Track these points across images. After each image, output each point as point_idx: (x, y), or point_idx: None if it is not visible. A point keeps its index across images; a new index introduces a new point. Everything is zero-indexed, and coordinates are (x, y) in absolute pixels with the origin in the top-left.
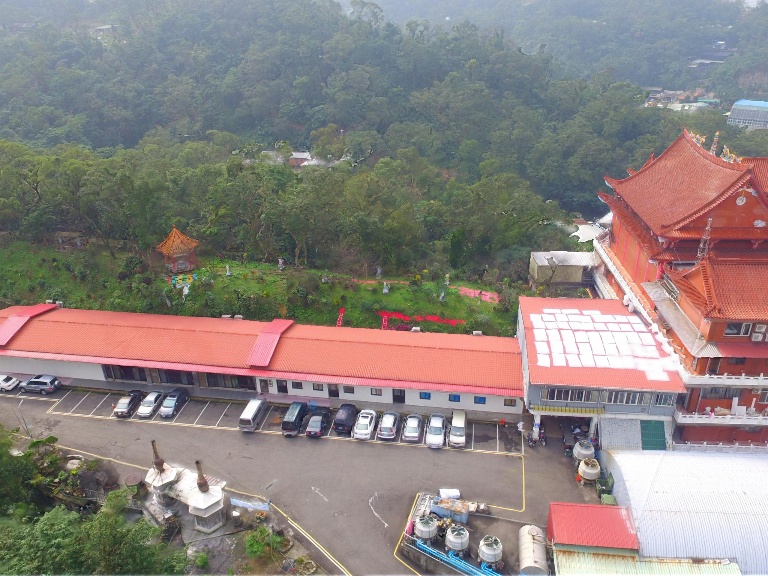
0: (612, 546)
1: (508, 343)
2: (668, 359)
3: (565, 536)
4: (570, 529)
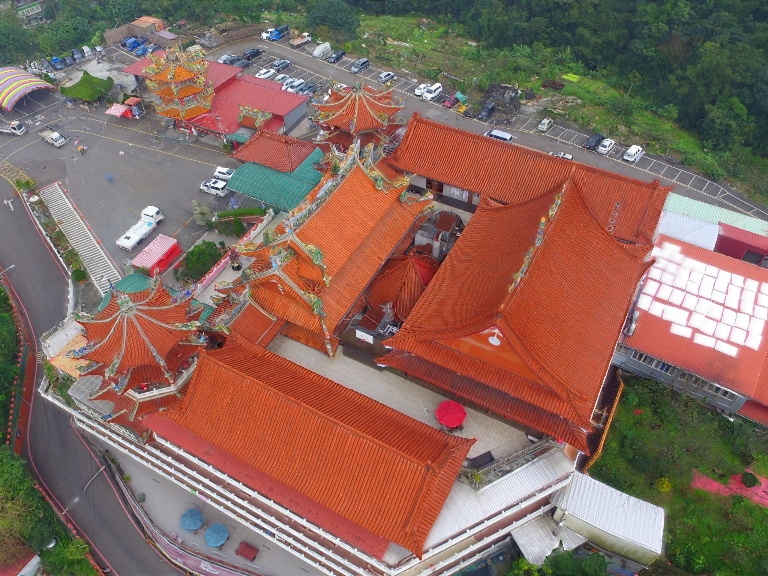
0: (736, 227)
1: (763, 383)
2: (653, 253)
3: (764, 238)
4: (760, 239)
